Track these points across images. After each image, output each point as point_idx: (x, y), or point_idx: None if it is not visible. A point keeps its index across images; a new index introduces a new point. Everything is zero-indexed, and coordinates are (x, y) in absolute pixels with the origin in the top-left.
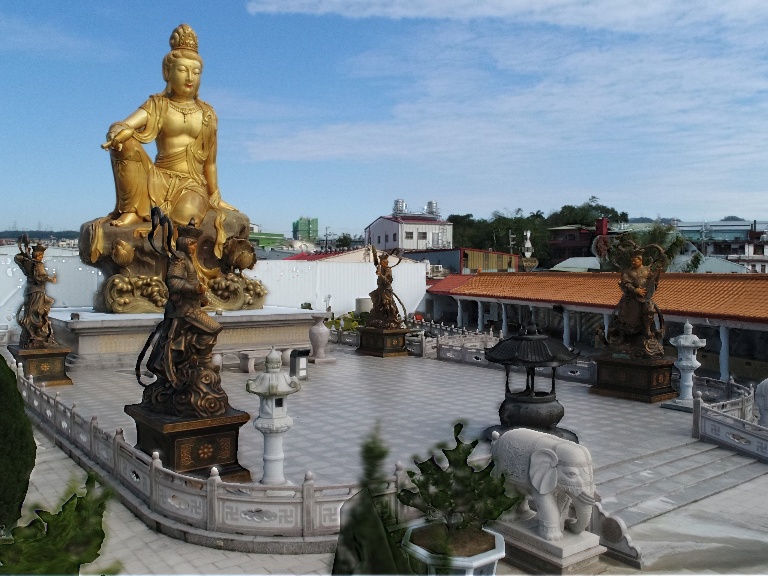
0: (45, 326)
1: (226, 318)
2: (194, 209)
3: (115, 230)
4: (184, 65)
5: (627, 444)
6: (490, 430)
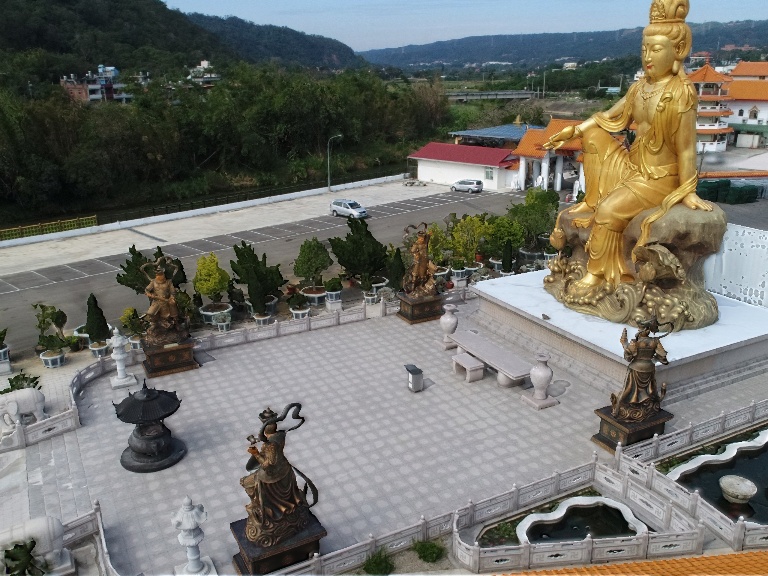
0: (428, 283)
1: (547, 324)
2: (608, 208)
3: (564, 216)
4: (644, 44)
5: (113, 489)
6: (173, 439)
